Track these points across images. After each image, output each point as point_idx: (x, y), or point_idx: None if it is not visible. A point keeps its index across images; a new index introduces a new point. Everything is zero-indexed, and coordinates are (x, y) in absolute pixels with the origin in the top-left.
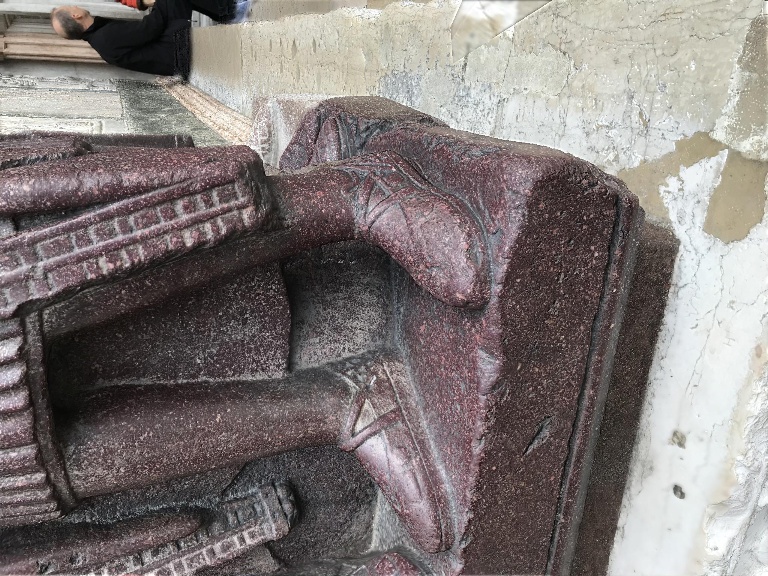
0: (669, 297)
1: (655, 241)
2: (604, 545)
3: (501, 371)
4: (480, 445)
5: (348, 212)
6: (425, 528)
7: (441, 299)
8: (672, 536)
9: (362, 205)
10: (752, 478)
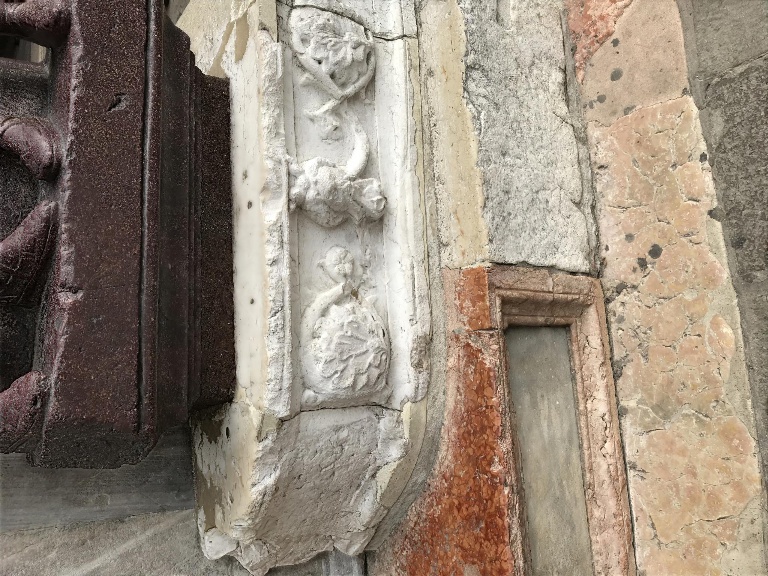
0: (230, 109)
1: (215, 77)
2: (226, 286)
3: (83, 51)
4: (75, 94)
5: (1, 5)
6: (42, 147)
7: (48, 21)
8: (252, 236)
9: (10, 3)
10: (278, 168)
